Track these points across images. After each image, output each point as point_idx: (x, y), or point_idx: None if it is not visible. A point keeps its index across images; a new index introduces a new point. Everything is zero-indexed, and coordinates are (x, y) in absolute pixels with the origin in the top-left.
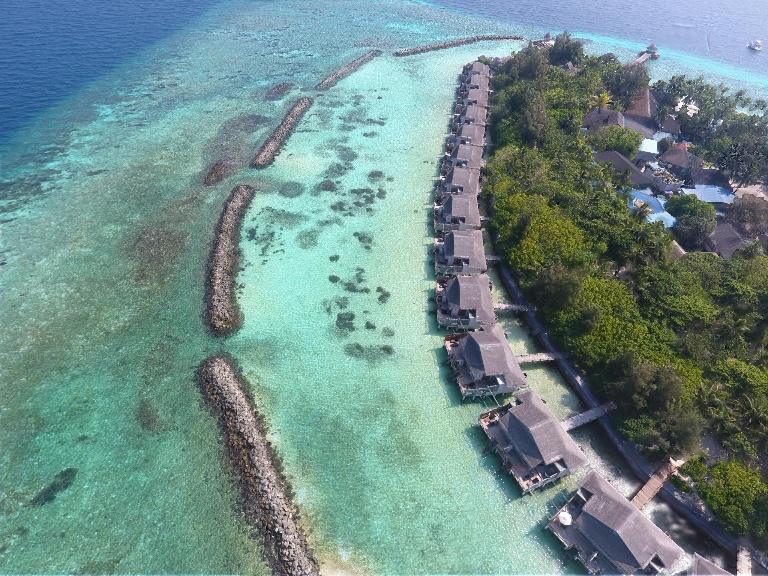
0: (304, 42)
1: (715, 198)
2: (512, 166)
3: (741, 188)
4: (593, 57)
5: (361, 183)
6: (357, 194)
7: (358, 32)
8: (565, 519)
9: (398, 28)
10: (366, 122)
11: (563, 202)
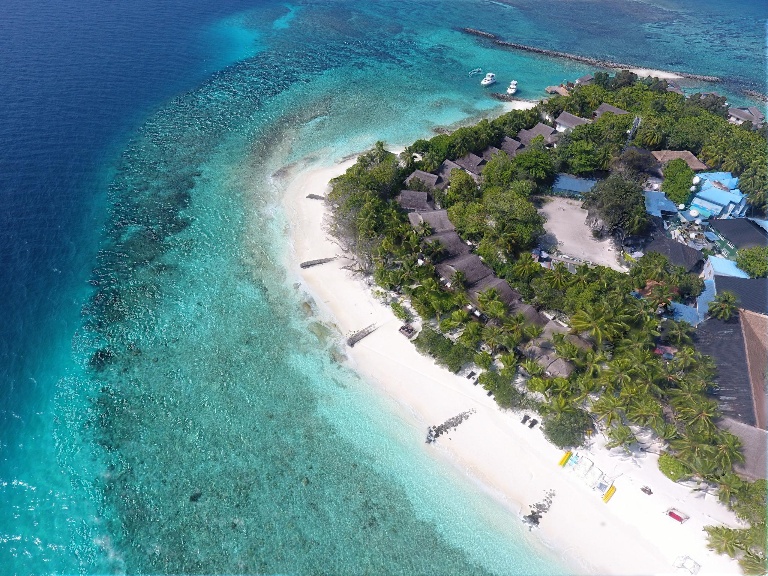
0: None
1: None
2: None
3: (581, 247)
4: None
5: None
6: None
7: None
8: None
9: None
10: None
11: None
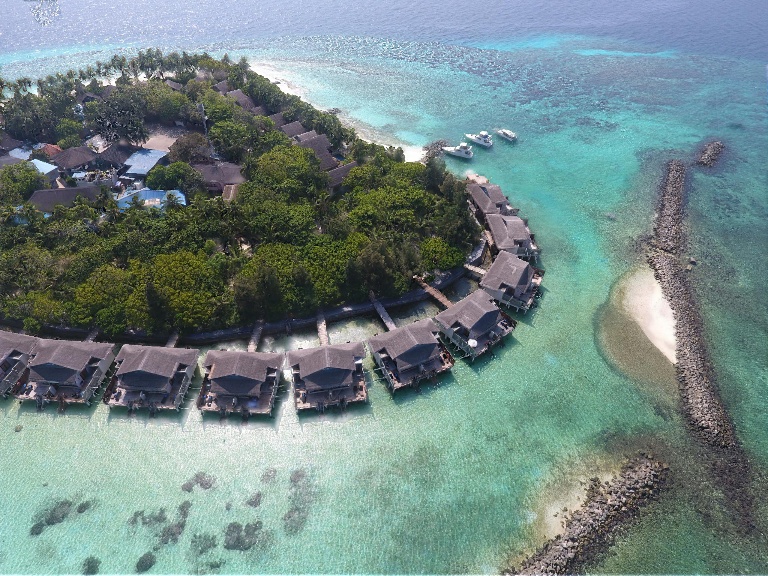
0: None
1: (152, 160)
2: (5, 285)
3: None
4: None
5: None
6: None
7: None
8: (474, 343)
9: None
10: None
11: (123, 253)
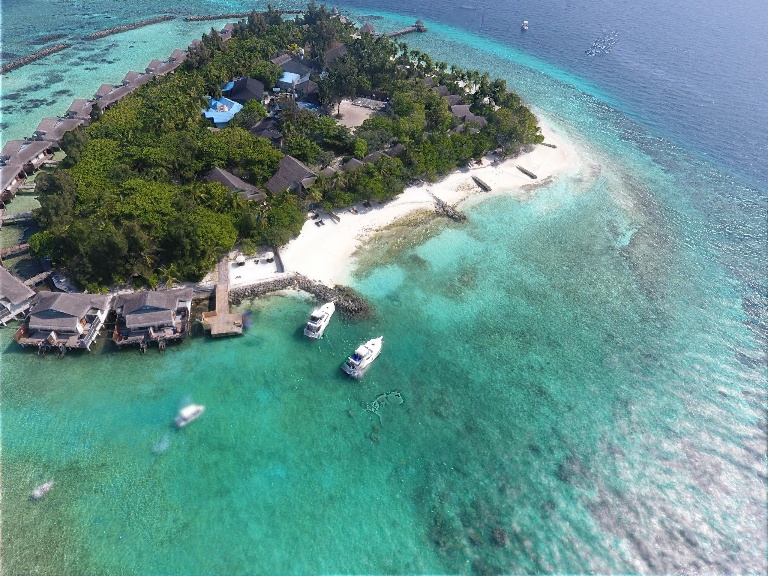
0: (114, 8)
1: None
2: None
3: (355, 112)
4: (331, 22)
5: (43, 96)
6: (31, 102)
7: (174, 4)
8: None
9: (215, 2)
10: (98, 61)
11: None
